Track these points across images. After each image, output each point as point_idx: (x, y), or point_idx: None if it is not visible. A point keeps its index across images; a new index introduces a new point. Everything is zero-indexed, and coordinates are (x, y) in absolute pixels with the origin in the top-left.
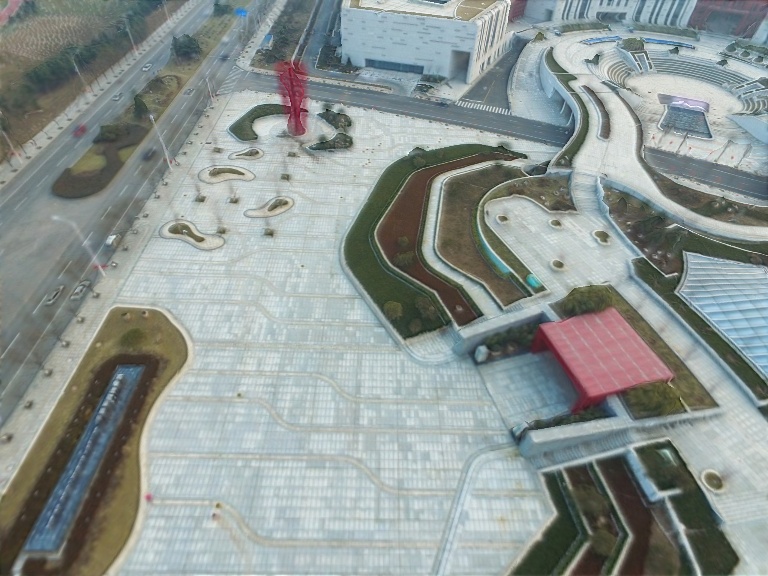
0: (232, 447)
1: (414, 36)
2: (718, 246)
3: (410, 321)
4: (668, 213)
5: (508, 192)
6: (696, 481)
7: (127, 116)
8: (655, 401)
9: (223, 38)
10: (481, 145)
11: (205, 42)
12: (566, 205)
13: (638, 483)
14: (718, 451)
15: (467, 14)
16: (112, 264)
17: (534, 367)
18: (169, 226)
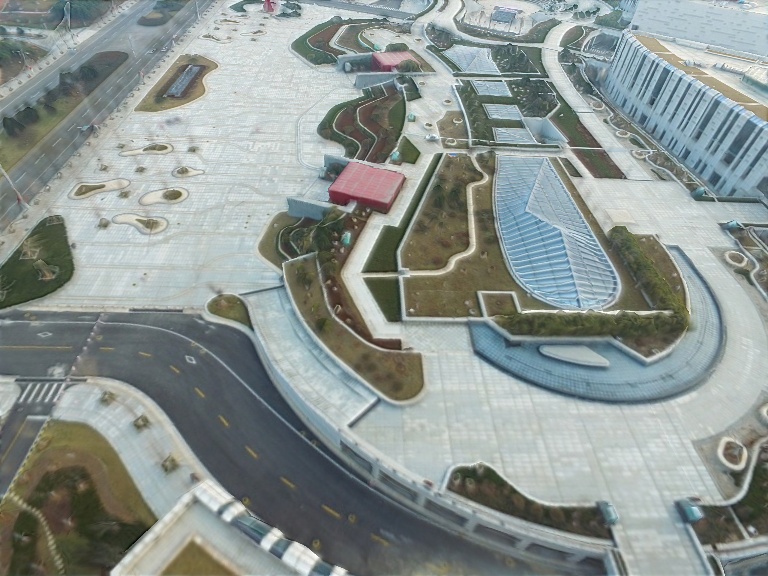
0: None
1: None
2: (472, 43)
3: None
4: (456, 35)
5: (378, 28)
6: (415, 83)
7: None
8: (406, 63)
9: None
10: None
11: None
12: None
13: (396, 87)
14: (429, 80)
15: None
16: (177, 43)
17: None
18: (202, 35)
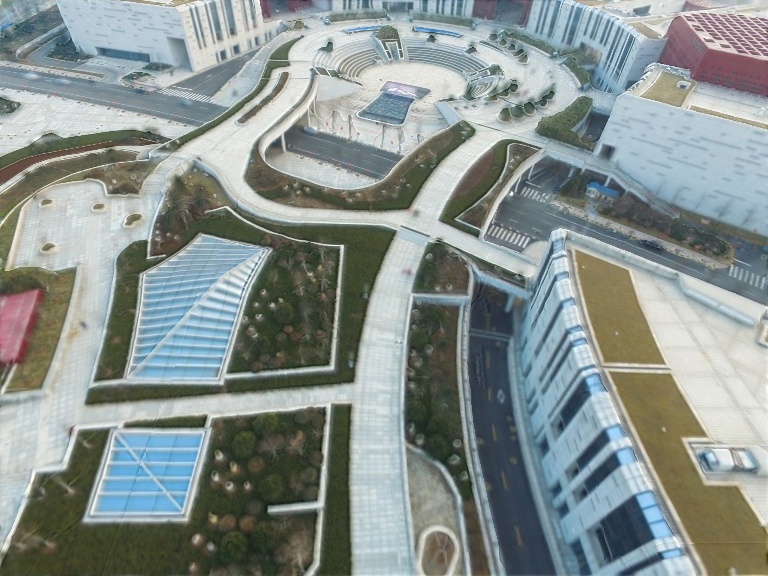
0: None
1: (127, 23)
2: (243, 228)
3: None
4: (229, 196)
5: (84, 176)
6: None
7: None
8: None
9: None
10: (136, 131)
11: None
12: (130, 189)
13: None
14: None
15: (186, 0)
16: None
17: None
18: None
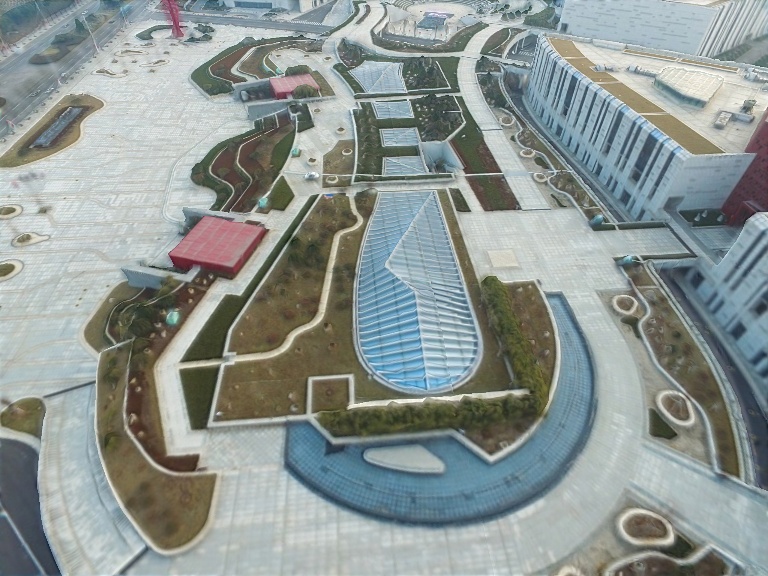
0: (122, 124)
1: None
2: (385, 58)
3: (215, 89)
4: (370, 50)
5: (288, 47)
6: (309, 110)
7: (72, 32)
8: (300, 88)
9: None
10: None
11: None
12: None
13: None
14: None
15: None
16: (65, 82)
17: None
18: (96, 71)
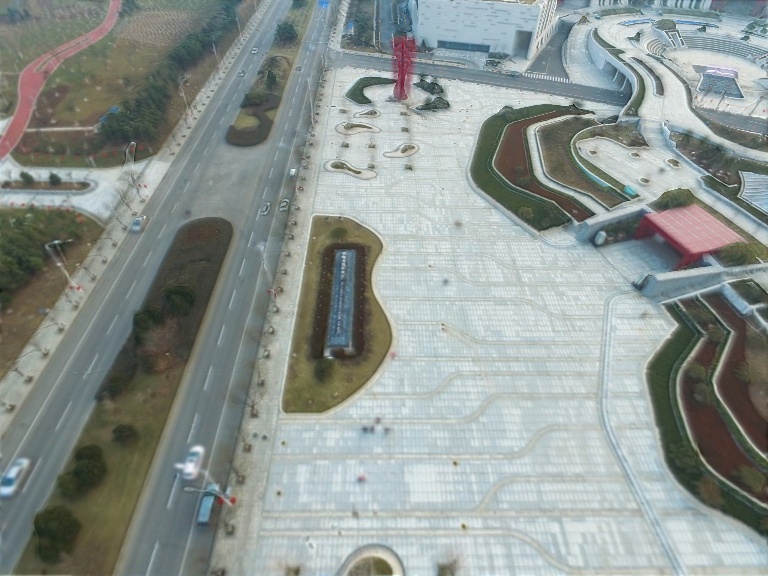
0: (438, 294)
1: (483, 19)
2: (765, 167)
3: (541, 219)
4: (722, 147)
5: (591, 135)
6: None
7: (259, 87)
8: (740, 252)
9: (308, 26)
10: (555, 105)
11: (296, 29)
12: (640, 143)
13: (733, 305)
14: None
15: None
16: (300, 188)
17: (639, 248)
18: (330, 163)
